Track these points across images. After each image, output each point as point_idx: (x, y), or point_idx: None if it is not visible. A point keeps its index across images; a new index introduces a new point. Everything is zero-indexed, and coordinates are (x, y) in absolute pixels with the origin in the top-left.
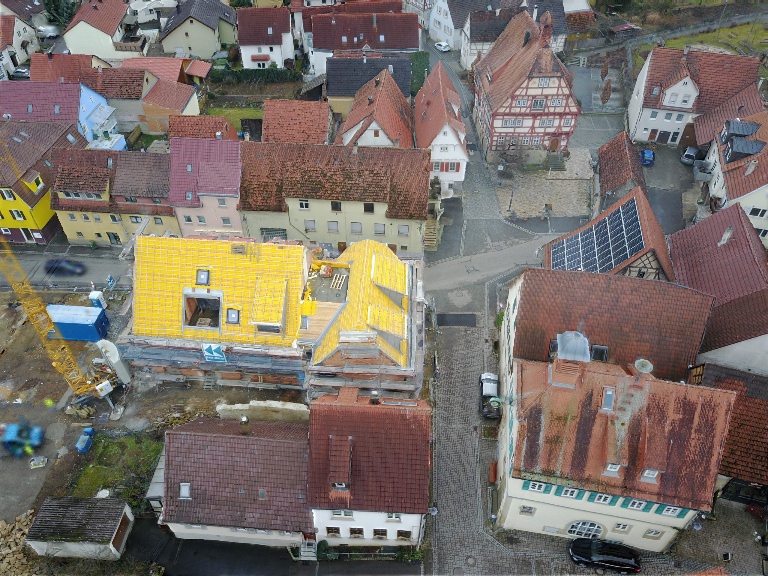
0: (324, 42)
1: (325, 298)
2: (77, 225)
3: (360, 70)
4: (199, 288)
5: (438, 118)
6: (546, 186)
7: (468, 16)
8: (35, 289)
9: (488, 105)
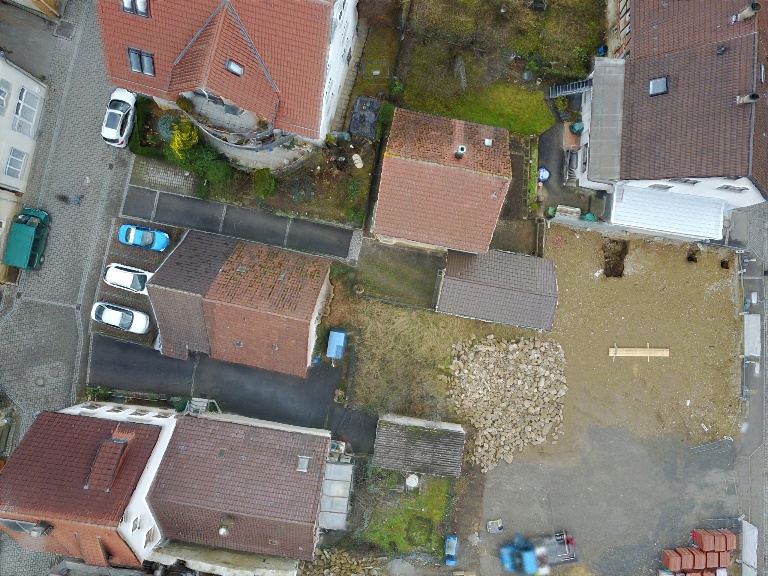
0: None
1: None
2: None
3: None
4: None
5: None
6: None
7: None
8: None
9: None
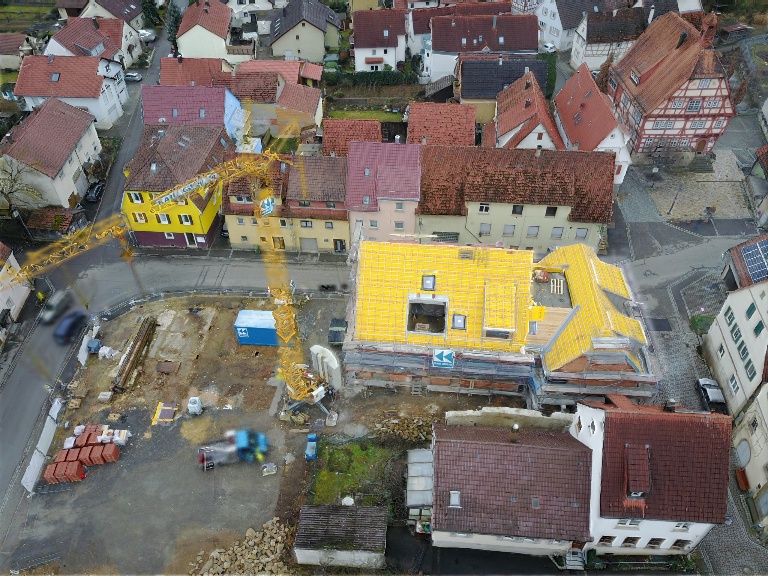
0: (443, 44)
1: (550, 303)
2: (244, 229)
3: (495, 72)
4: (424, 293)
5: (602, 120)
6: (699, 188)
7: (584, 17)
8: (210, 294)
9: (639, 107)
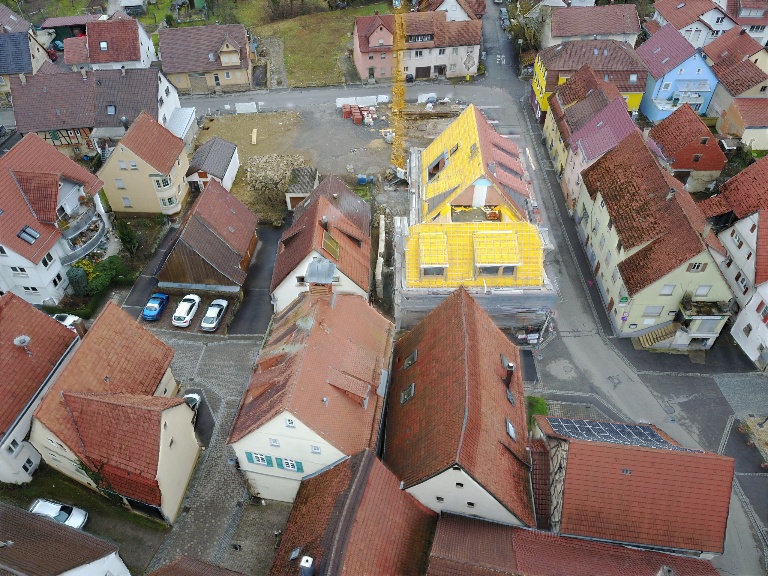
0: None
1: (460, 219)
2: None
3: None
4: (448, 154)
5: None
6: None
7: None
8: None
9: None
